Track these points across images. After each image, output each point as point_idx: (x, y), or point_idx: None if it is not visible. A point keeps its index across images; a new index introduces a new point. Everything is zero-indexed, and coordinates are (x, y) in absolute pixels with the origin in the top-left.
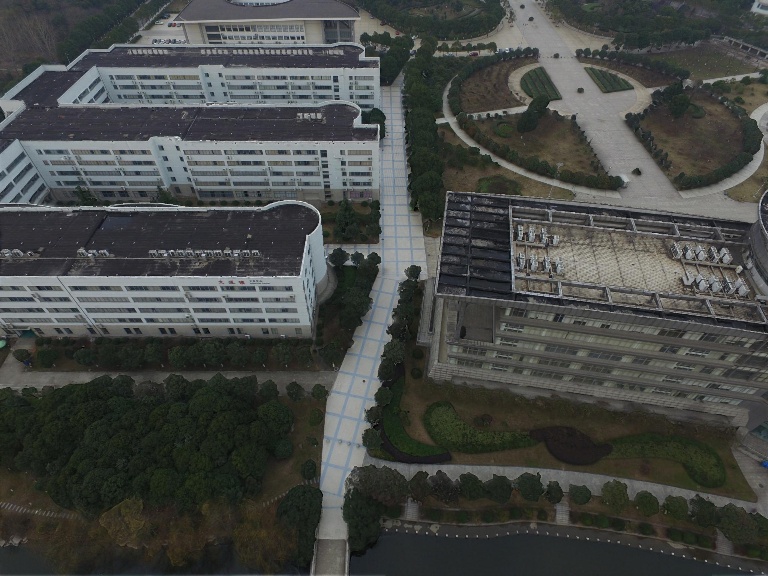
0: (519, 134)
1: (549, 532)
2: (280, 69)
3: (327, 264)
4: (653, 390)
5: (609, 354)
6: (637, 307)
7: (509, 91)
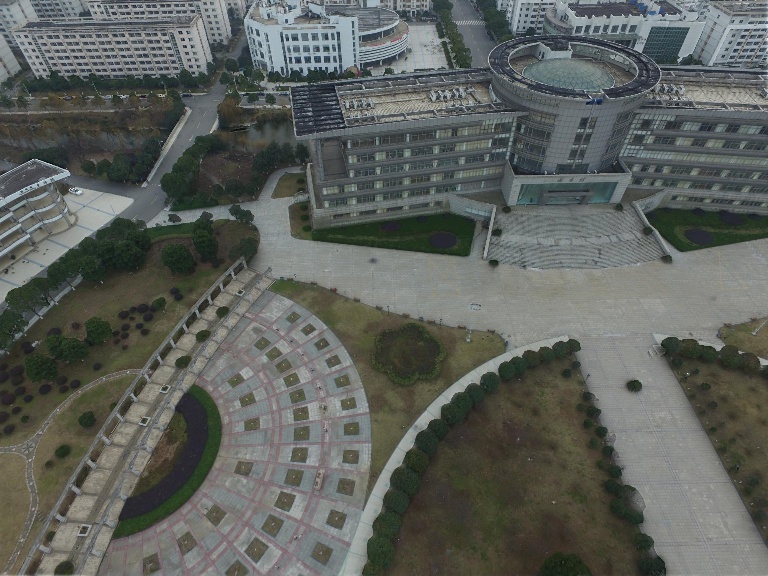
0: None
1: None
2: None
3: None
4: None
5: None
6: (714, 73)
7: None
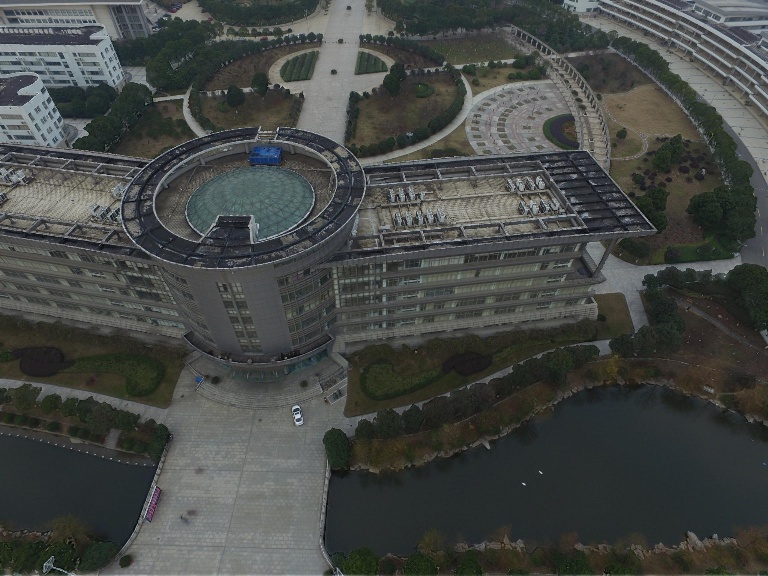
0: (238, 109)
1: None
2: (7, 45)
3: None
4: (118, 315)
5: (48, 278)
6: (8, 229)
7: (266, 72)
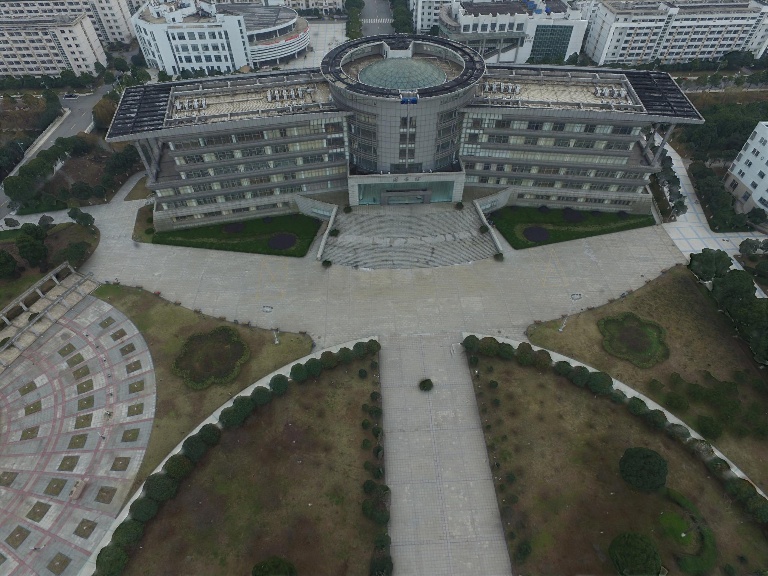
0: (643, 498)
1: None
2: None
3: (764, 231)
4: None
5: None
6: None
7: None
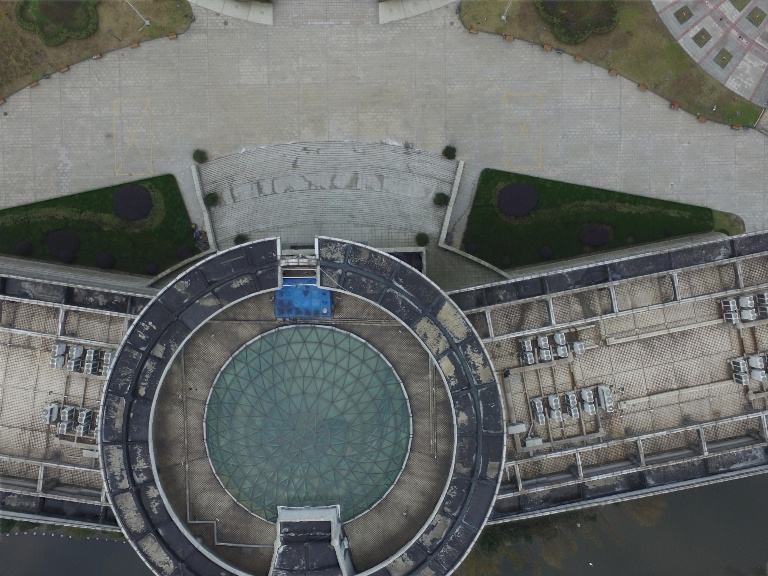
0: None
1: (47, 532)
2: None
3: None
4: None
5: None
6: None
7: None
